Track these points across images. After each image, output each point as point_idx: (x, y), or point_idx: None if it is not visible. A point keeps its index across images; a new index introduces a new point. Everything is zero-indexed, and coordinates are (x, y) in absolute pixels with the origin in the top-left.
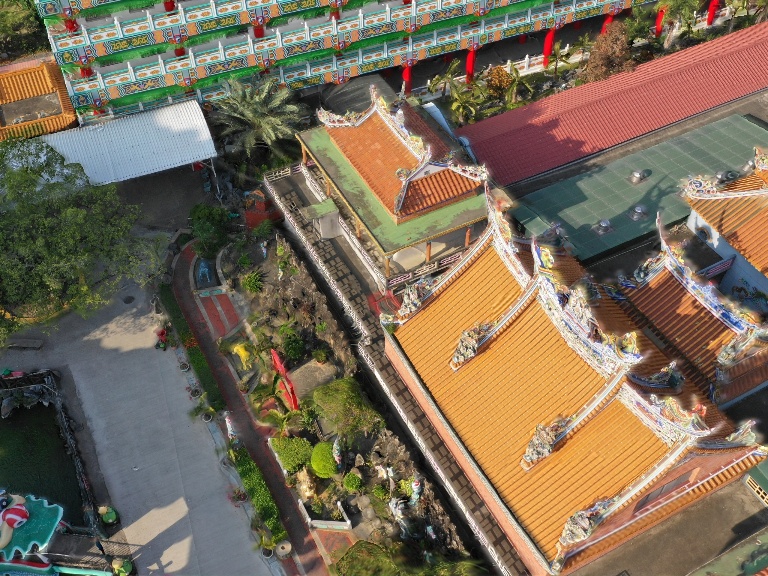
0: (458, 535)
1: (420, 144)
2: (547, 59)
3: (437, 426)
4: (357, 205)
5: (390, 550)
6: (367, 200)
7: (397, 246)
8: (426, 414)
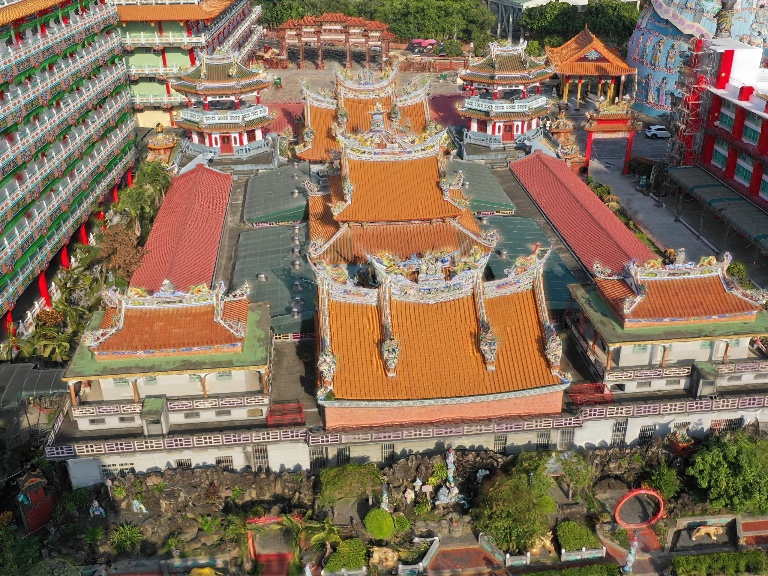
0: (497, 454)
1: (207, 289)
2: (48, 299)
3: (419, 417)
4: (197, 367)
5: (472, 520)
6: (196, 361)
7: (264, 359)
8: (403, 422)
